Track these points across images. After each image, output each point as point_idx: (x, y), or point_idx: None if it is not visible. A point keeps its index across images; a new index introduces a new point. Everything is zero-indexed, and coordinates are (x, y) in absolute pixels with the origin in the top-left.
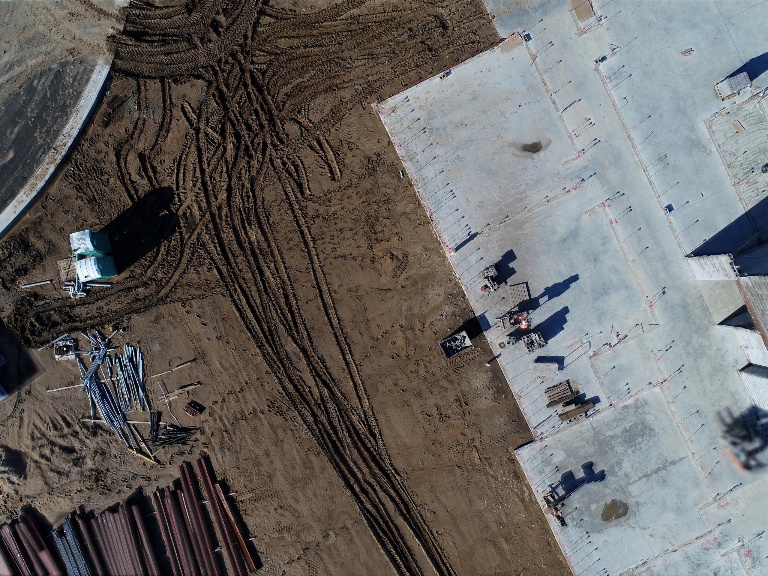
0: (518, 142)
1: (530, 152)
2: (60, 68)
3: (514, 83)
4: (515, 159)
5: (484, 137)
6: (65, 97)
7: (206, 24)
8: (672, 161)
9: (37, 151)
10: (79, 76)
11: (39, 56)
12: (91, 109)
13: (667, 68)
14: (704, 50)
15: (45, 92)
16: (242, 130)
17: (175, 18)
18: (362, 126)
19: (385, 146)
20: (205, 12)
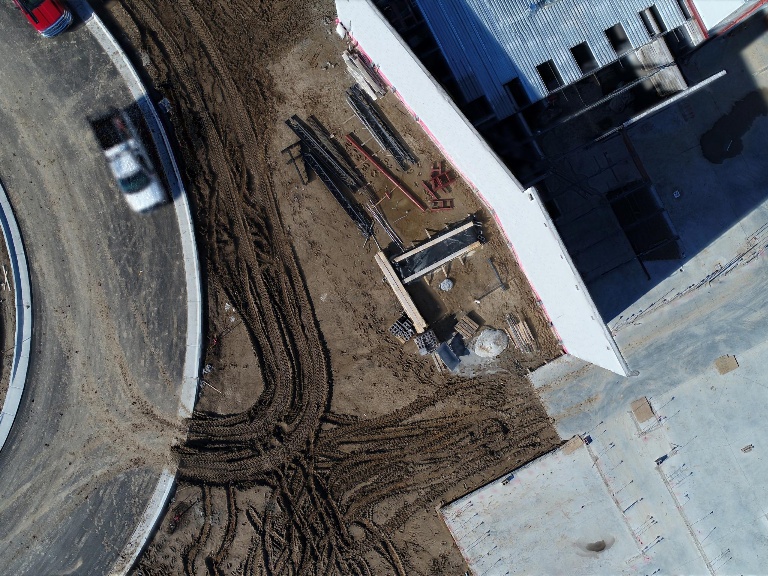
0: (582, 542)
1: (594, 551)
2: (125, 477)
3: (576, 484)
4: (579, 558)
5: (548, 538)
6: (131, 505)
7: (268, 430)
8: (735, 555)
9: (105, 559)
10: (144, 485)
11: (104, 467)
12: (157, 518)
13: (727, 465)
14: (764, 446)
15: (111, 501)
16: (307, 533)
17: (237, 426)
18: (426, 528)
19: (450, 548)
20: (267, 418)
